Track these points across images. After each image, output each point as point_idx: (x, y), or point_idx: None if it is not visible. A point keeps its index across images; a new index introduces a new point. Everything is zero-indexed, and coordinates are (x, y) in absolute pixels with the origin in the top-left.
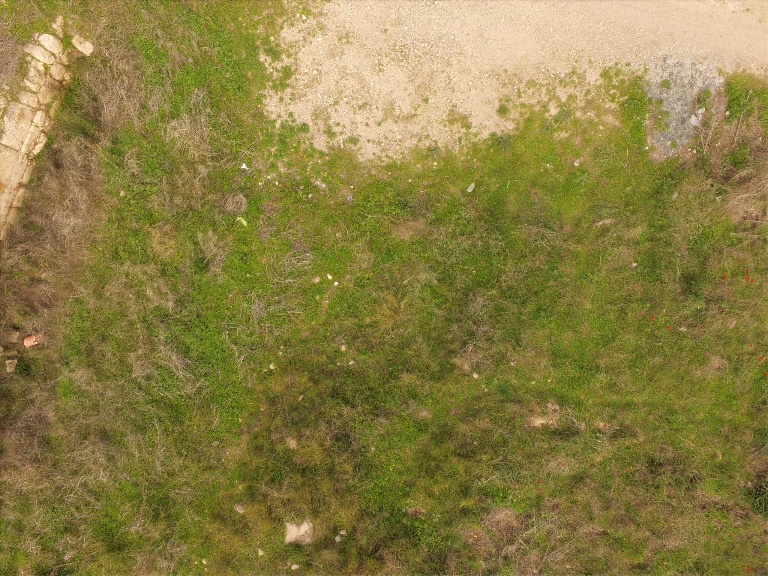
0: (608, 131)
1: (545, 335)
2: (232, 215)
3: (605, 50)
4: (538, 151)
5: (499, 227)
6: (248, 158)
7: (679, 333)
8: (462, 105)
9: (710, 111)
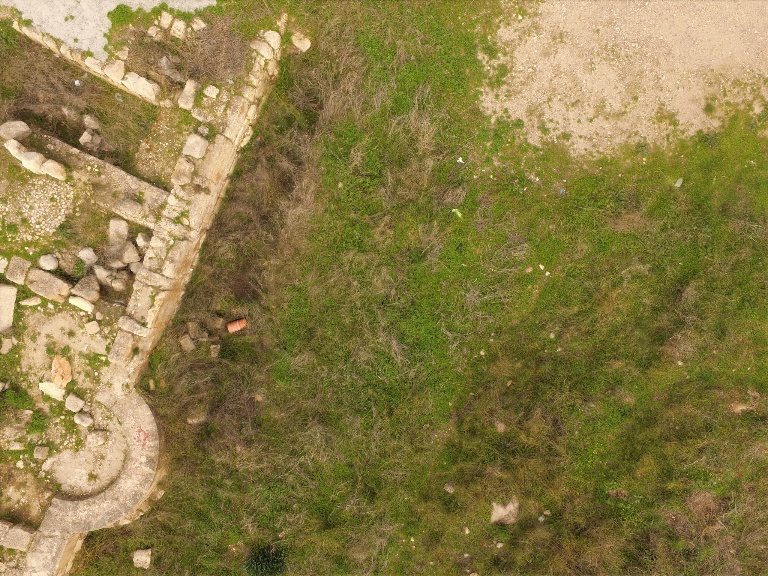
0: None
1: (747, 325)
2: (449, 207)
3: None
4: (743, 148)
5: (707, 221)
6: (465, 152)
7: None
8: (670, 103)
9: None
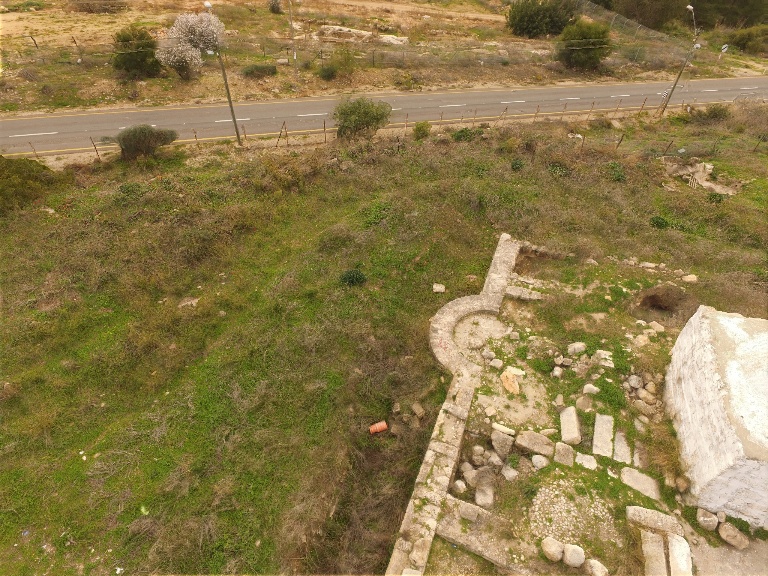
0: None
1: None
2: None
3: None
4: None
5: None
6: None
7: None
8: None
9: None
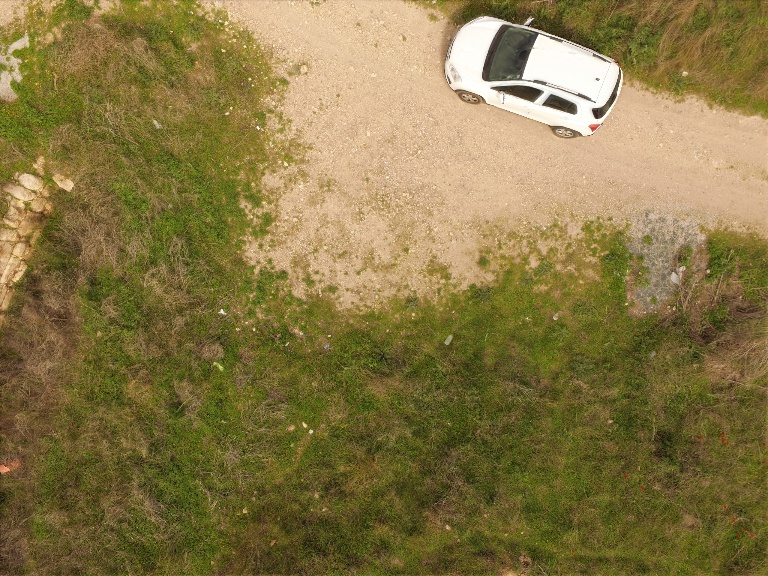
0: (588, 286)
1: (519, 488)
2: (208, 360)
3: (587, 204)
4: (517, 304)
5: (475, 381)
6: (226, 304)
7: (653, 491)
8: (442, 256)
9: (691, 269)
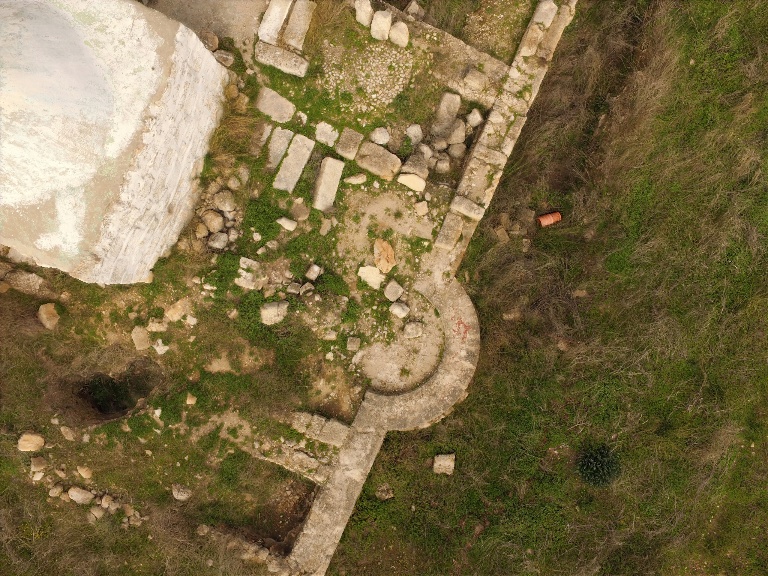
0: None
1: None
2: None
3: None
4: None
5: None
6: None
7: None
8: None
9: None
